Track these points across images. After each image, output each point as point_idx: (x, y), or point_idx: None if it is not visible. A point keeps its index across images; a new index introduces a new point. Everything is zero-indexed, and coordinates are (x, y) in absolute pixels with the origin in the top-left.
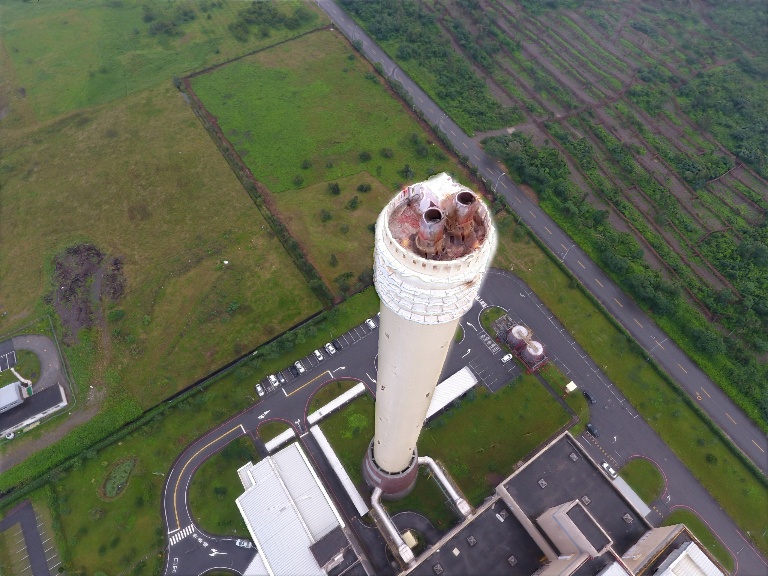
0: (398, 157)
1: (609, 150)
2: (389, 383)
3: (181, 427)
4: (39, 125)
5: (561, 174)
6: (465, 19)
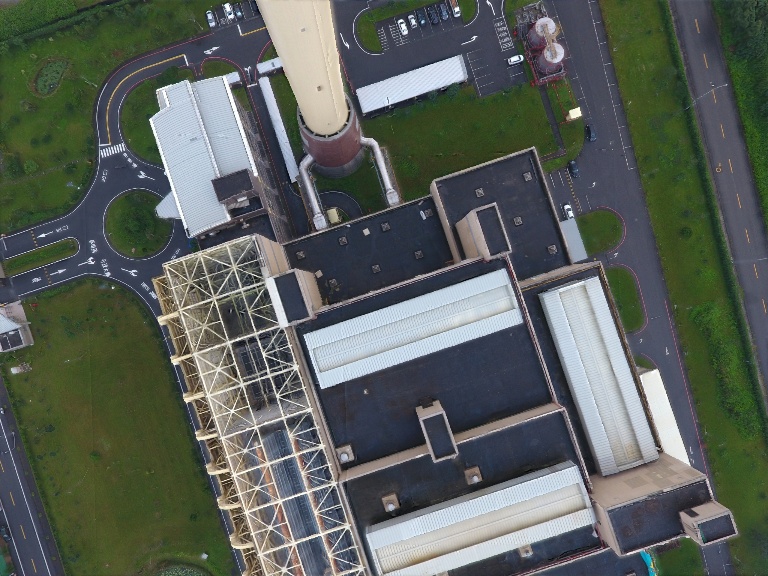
0: None
1: None
2: None
3: (118, 39)
4: None
5: None
6: None
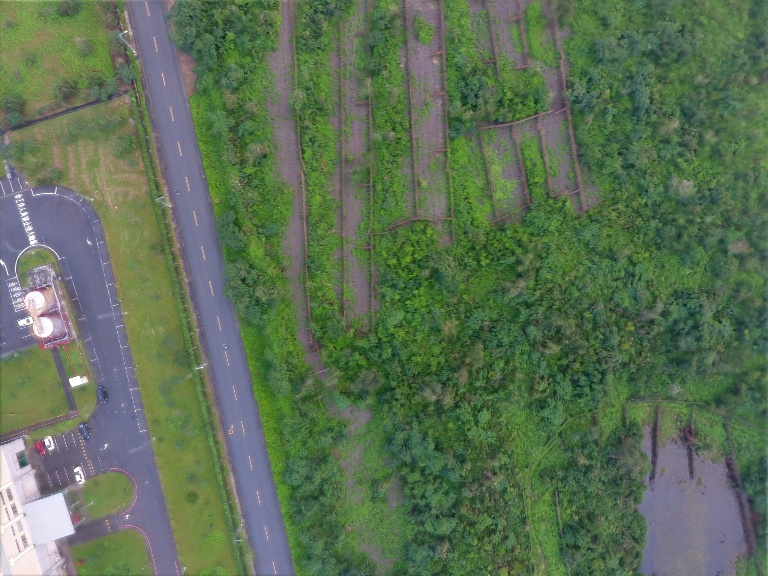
0: None
1: (373, 17)
2: None
3: None
4: None
5: (252, 49)
6: None
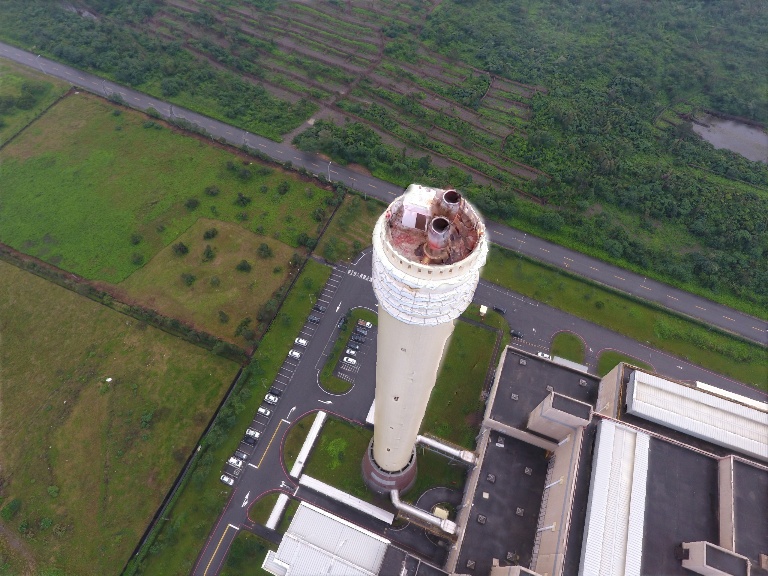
0: (225, 190)
1: (398, 105)
2: (405, 391)
3: (167, 570)
4: None
5: (375, 141)
6: (209, 36)
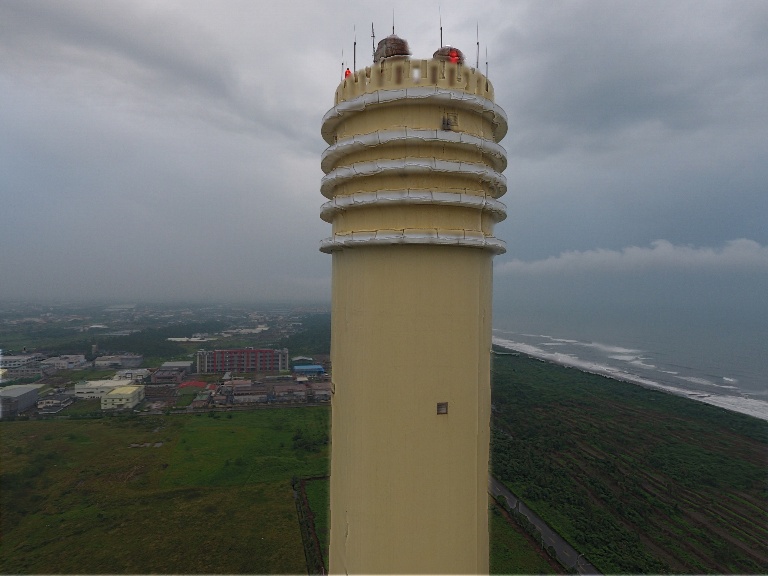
0: None
1: None
2: None
3: None
4: (156, 491)
5: None
6: (603, 479)
